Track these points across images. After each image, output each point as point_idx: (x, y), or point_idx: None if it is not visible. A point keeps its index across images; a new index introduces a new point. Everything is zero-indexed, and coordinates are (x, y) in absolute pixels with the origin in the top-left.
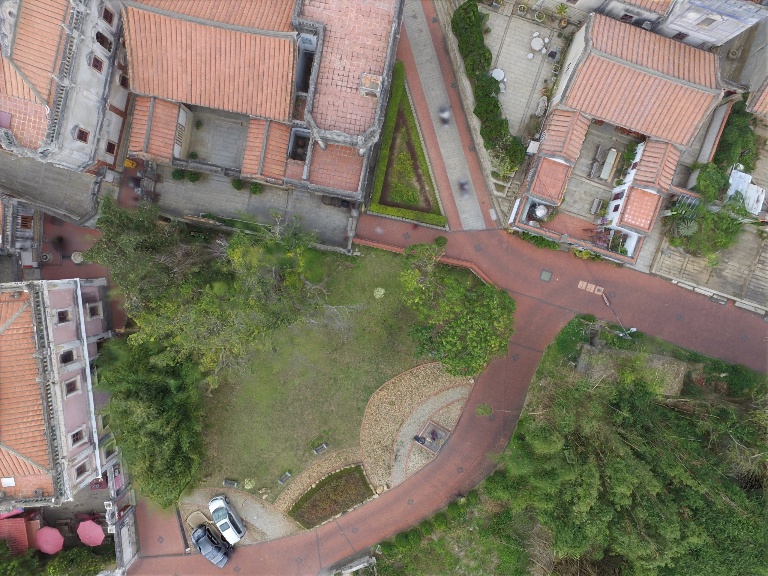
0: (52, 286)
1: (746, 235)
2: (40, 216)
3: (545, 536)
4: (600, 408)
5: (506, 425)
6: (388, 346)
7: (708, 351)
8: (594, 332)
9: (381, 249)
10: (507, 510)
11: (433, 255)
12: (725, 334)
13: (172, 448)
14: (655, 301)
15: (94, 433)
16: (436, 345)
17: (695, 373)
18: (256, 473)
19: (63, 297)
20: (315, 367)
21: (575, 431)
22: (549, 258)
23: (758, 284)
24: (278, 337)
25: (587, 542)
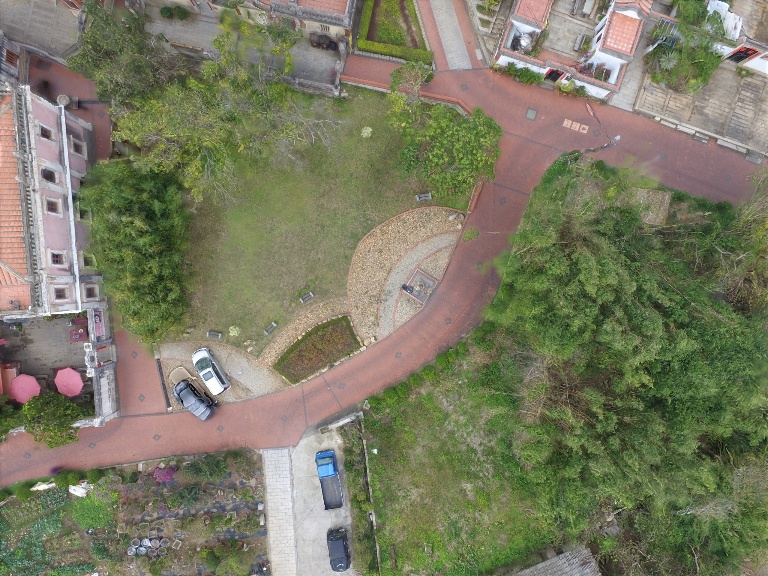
0: (35, 97)
1: (726, 73)
2: (26, 59)
3: (534, 386)
4: (586, 221)
5: (494, 273)
6: (375, 192)
7: (692, 190)
8: (580, 172)
9: (368, 89)
10: (496, 361)
11: (419, 73)
12: (708, 173)
13: (155, 273)
14: (639, 139)
15: (75, 265)
16: (423, 163)
17: (680, 213)
18: (241, 325)
19: (46, 116)
20: (302, 213)
21: (562, 240)
22: (534, 96)
23: (739, 122)
24: (265, 183)
25: (575, 340)
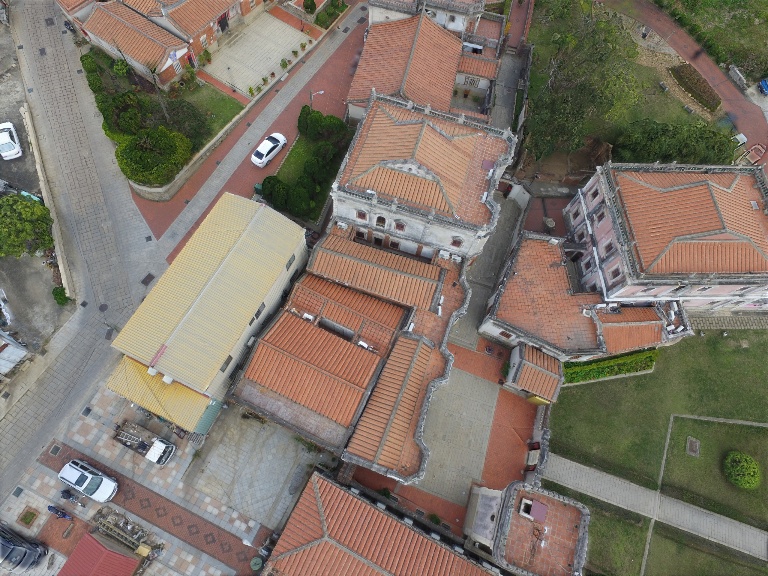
0: None
1: None
2: None
3: None
4: None
5: None
6: None
7: None
8: None
9: None
10: None
11: None
12: None
13: None
14: None
15: None
16: None
17: None
18: None
19: None
20: None
21: None
22: None
23: None
24: None
25: None
